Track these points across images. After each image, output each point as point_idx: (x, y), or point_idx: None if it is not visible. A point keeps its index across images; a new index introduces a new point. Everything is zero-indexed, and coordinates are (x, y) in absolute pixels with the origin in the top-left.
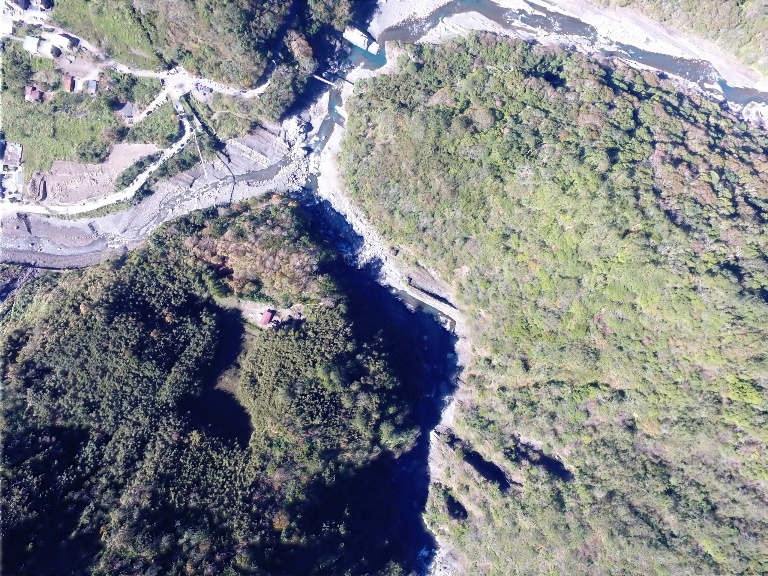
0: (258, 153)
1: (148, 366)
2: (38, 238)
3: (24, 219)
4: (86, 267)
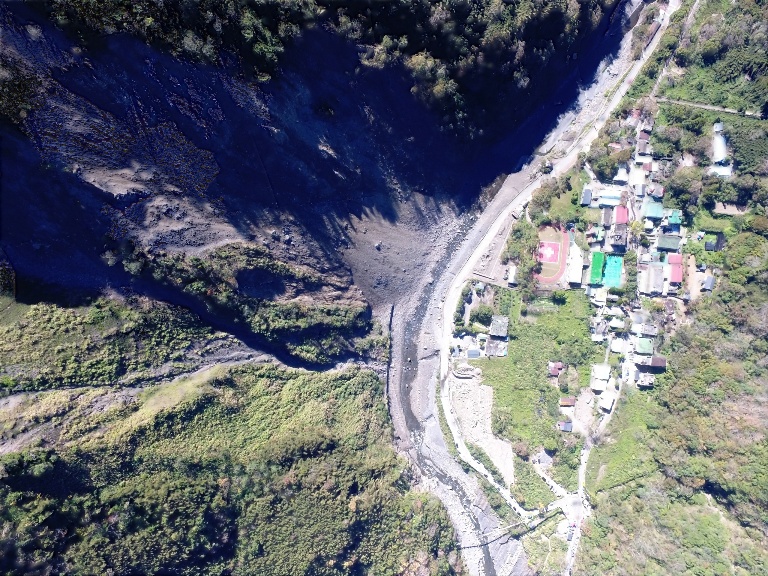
0: (511, 570)
1: (300, 575)
2: (416, 366)
3: (434, 354)
4: (391, 419)
